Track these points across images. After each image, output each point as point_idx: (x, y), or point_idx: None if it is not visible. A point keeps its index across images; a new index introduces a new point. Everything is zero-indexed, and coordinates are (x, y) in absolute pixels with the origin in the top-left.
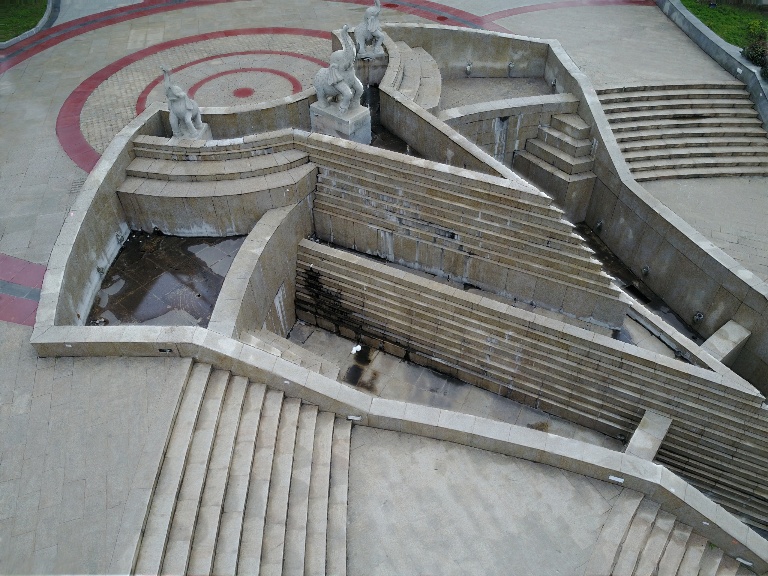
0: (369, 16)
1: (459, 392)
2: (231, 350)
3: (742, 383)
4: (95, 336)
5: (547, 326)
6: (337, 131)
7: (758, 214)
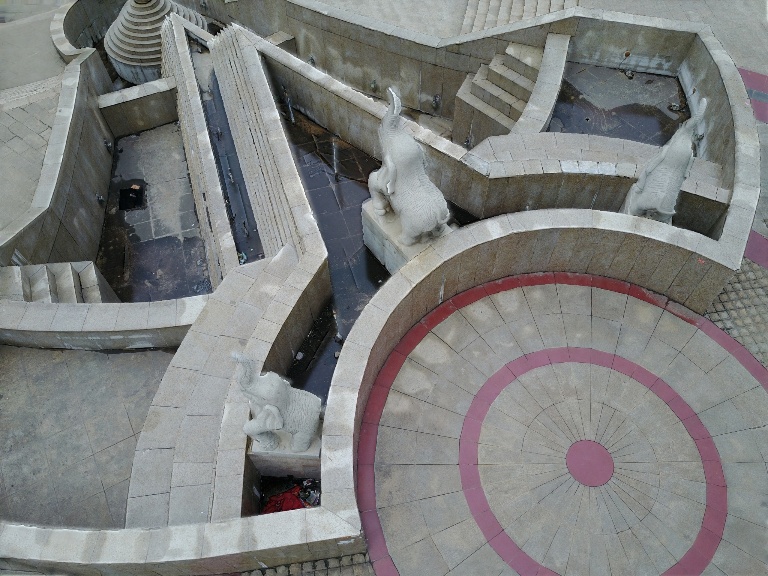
0: None
1: None
2: None
3: (176, 18)
4: (656, 21)
5: None
6: None
7: None
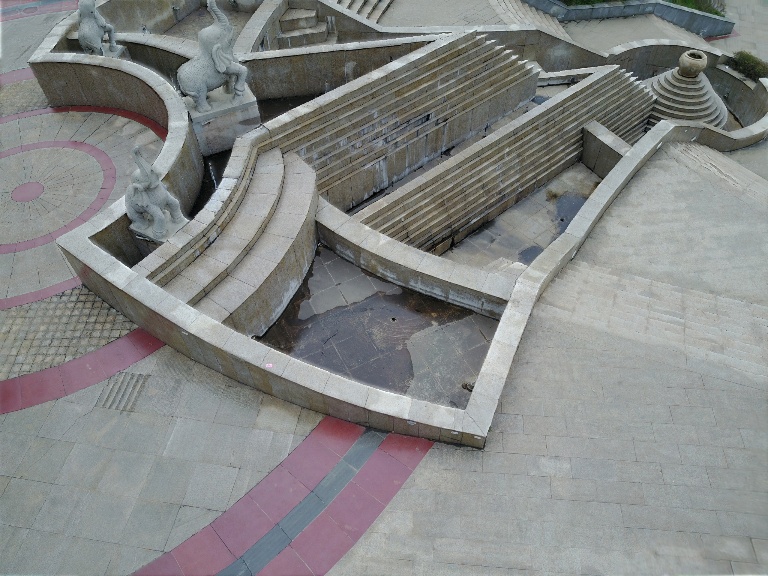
0: (92, 9)
1: (501, 226)
2: (540, 273)
3: (607, 67)
4: (500, 369)
5: (523, 123)
6: (242, 122)
7: (446, 3)
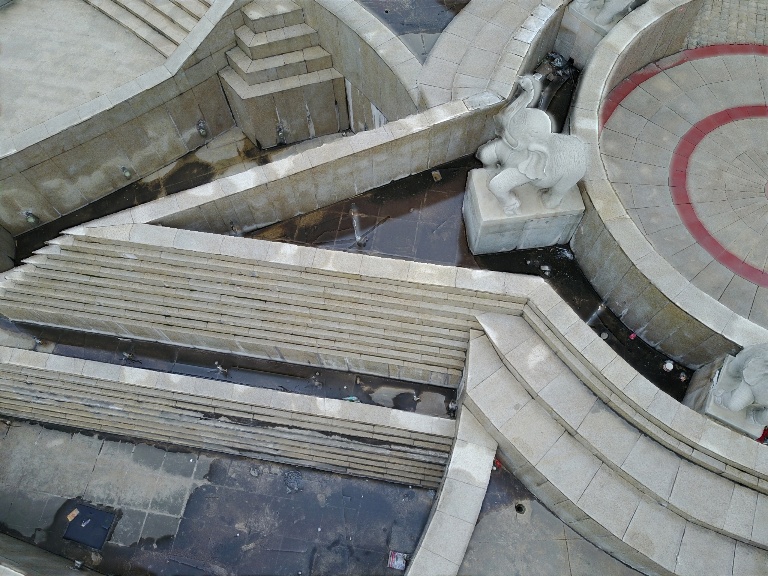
0: None
1: None
2: None
3: None
4: None
5: None
6: None
7: None
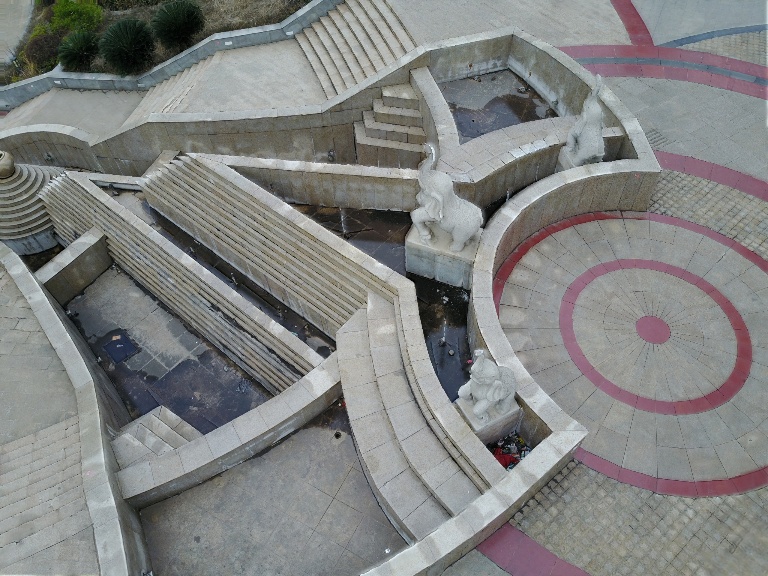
0: None
1: None
2: (402, 60)
3: (75, 175)
4: (482, 35)
5: None
6: None
7: None
